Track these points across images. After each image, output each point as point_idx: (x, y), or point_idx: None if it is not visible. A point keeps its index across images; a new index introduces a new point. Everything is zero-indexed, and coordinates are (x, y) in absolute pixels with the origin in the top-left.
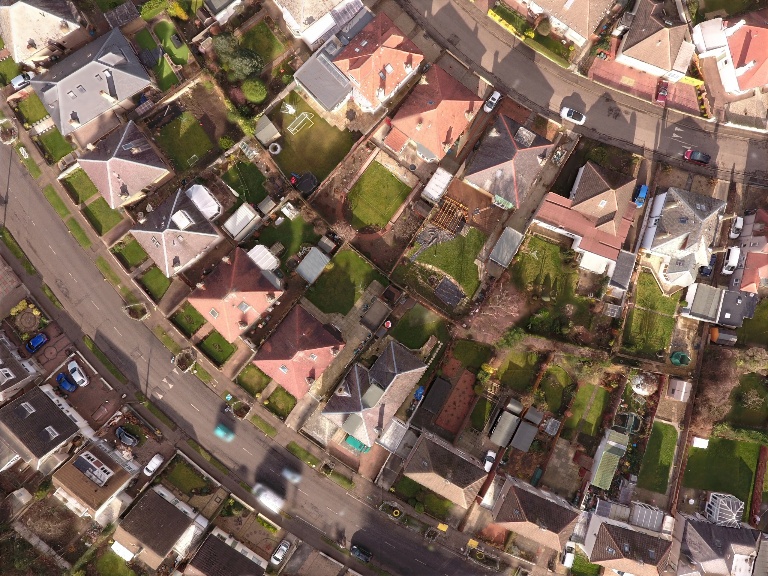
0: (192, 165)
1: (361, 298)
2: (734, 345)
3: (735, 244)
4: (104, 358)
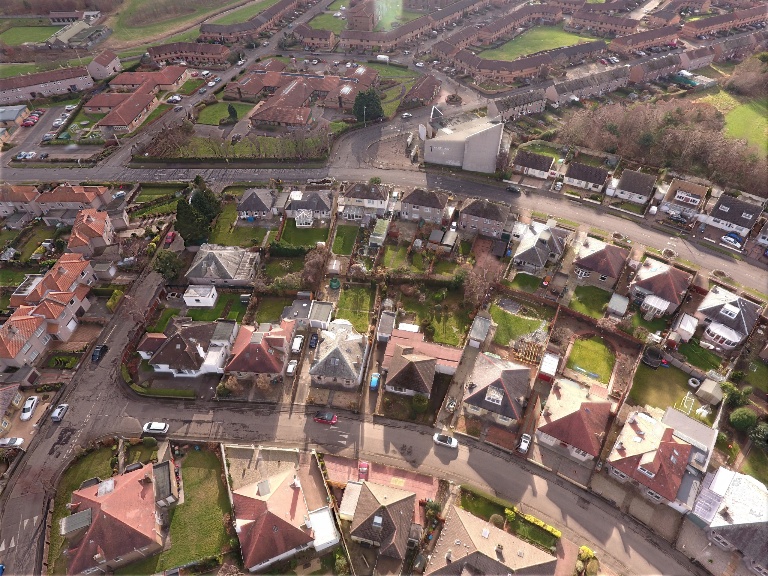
0: (751, 363)
1: (571, 296)
2: (293, 297)
3: (291, 358)
4: (721, 251)
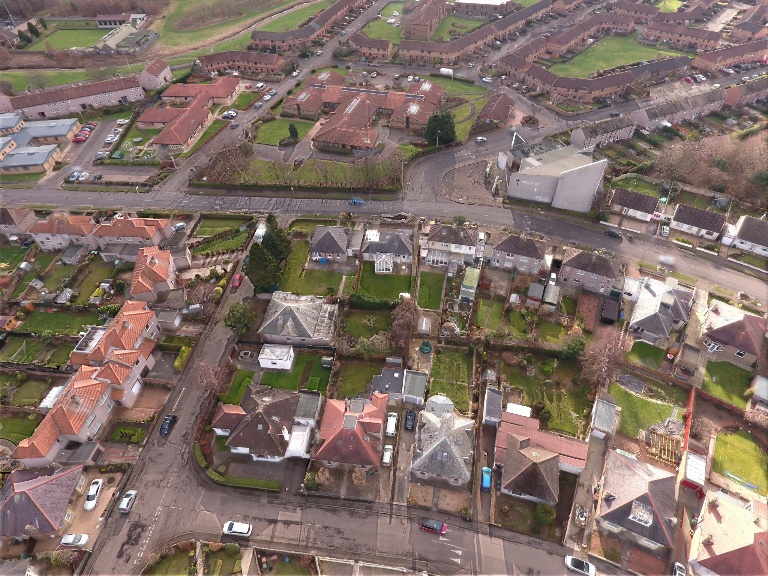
0: None
1: (703, 374)
2: (380, 361)
3: (384, 441)
4: None
